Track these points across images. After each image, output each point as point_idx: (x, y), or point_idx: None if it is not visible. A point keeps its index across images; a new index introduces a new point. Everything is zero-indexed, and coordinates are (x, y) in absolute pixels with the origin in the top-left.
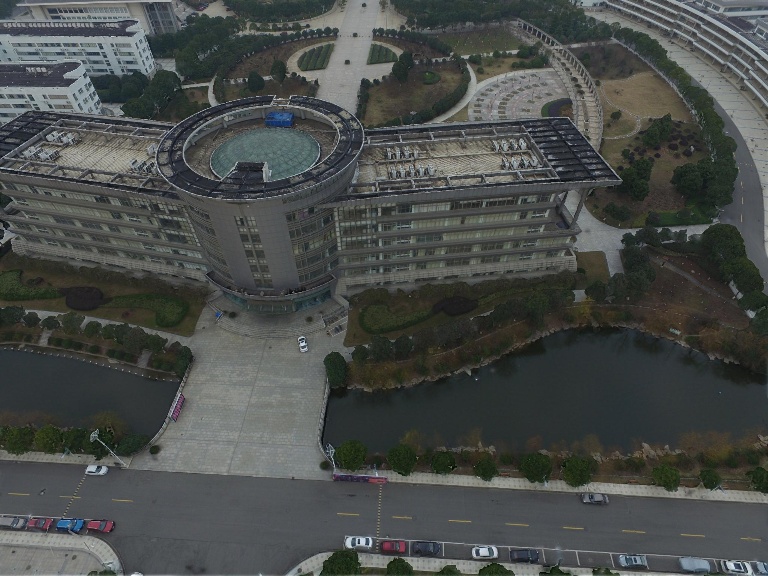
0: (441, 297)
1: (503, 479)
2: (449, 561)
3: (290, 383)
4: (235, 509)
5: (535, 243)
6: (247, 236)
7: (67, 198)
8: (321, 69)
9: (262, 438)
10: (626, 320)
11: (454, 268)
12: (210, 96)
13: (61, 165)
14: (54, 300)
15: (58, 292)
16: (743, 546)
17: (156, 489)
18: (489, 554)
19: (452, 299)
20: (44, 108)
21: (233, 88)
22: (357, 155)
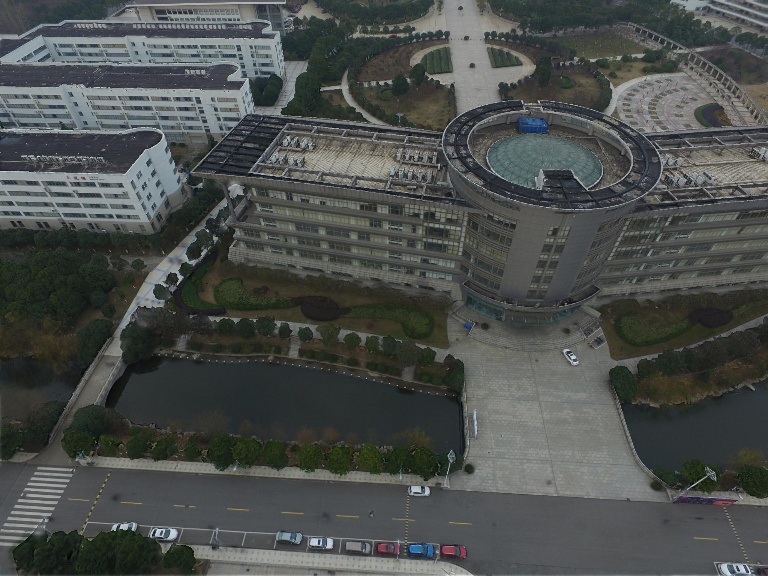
0: (691, 308)
1: None
2: None
3: (576, 398)
4: (584, 533)
5: None
6: (551, 246)
7: (326, 205)
8: (449, 72)
9: (575, 457)
10: None
11: (706, 278)
12: (348, 99)
13: (324, 171)
14: (288, 310)
15: (291, 301)
16: None
17: (490, 511)
18: None
19: (705, 310)
20: (209, 111)
21: (367, 91)
22: None
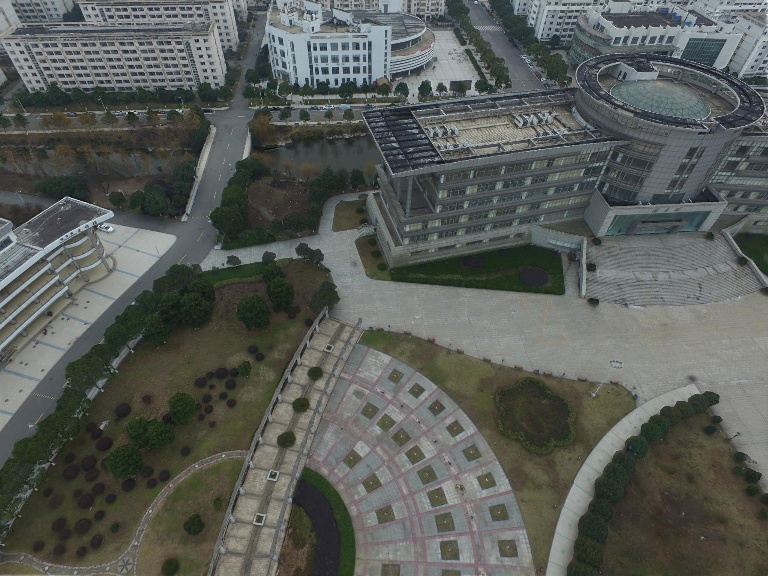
0: None
1: None
2: None
3: None
4: None
5: None
6: None
7: None
8: None
9: None
10: None
11: None
12: None
13: None
14: None
15: None
16: None
17: None
18: None
19: None
20: None
21: None
22: (576, 78)
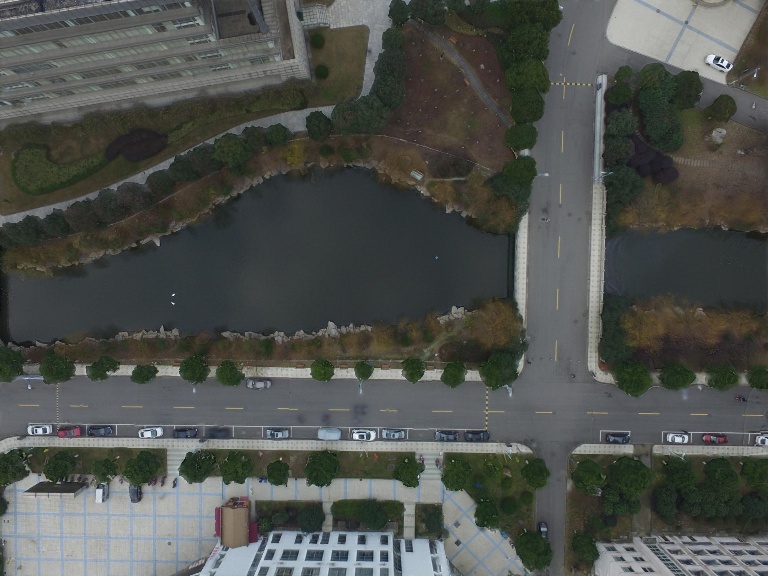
0: None
1: (176, 368)
2: (120, 439)
3: None
4: None
5: (218, 53)
6: None
7: None
8: None
9: None
10: (362, 158)
11: (116, 91)
12: None
13: None
14: None
15: None
16: (379, 417)
17: None
18: (152, 436)
19: (131, 136)
20: None
21: None
22: None
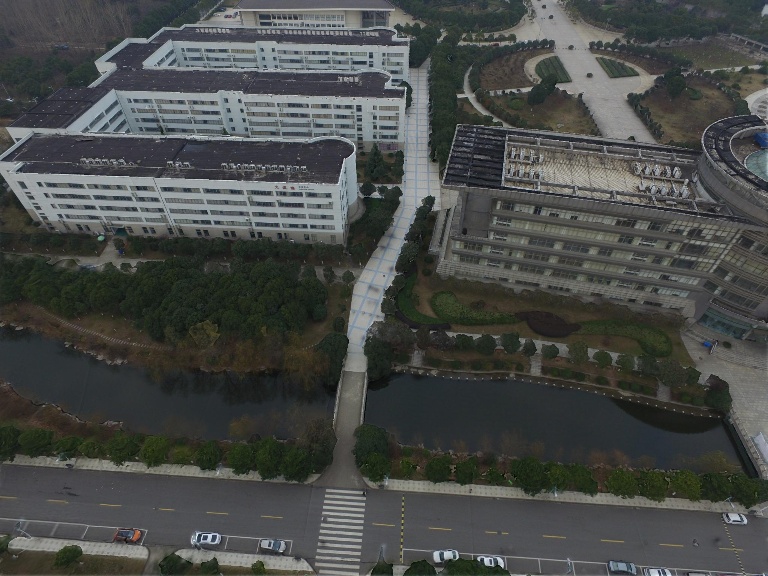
0: None
1: None
2: None
3: None
4: None
5: None
6: None
7: (577, 220)
8: (569, 82)
9: None
10: None
11: None
12: (478, 108)
13: (579, 186)
14: (514, 325)
15: (515, 317)
16: None
17: None
18: None
19: None
20: (367, 119)
21: (495, 100)
22: None
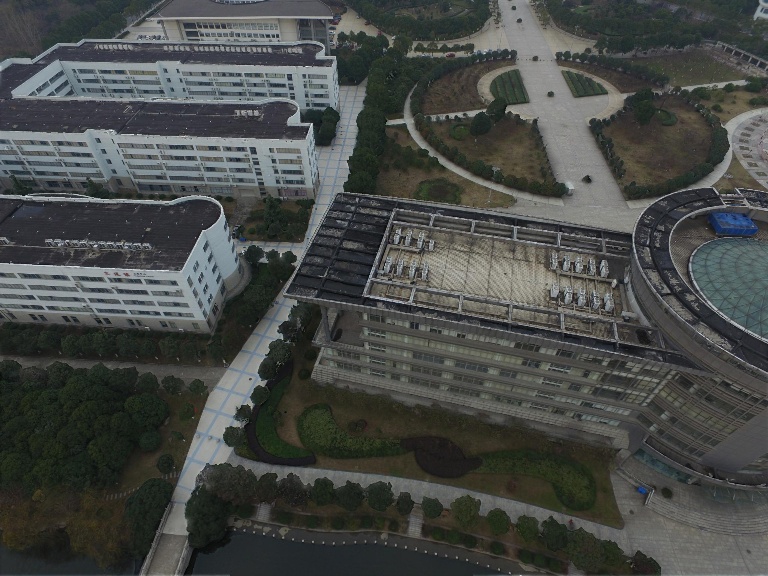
0: None
1: None
2: None
3: None
4: None
5: None
6: None
7: (465, 339)
8: (525, 103)
9: None
10: None
11: None
12: (415, 137)
13: (466, 295)
14: (397, 458)
15: (400, 446)
16: None
17: None
18: None
19: None
20: (265, 163)
21: (436, 127)
22: None
